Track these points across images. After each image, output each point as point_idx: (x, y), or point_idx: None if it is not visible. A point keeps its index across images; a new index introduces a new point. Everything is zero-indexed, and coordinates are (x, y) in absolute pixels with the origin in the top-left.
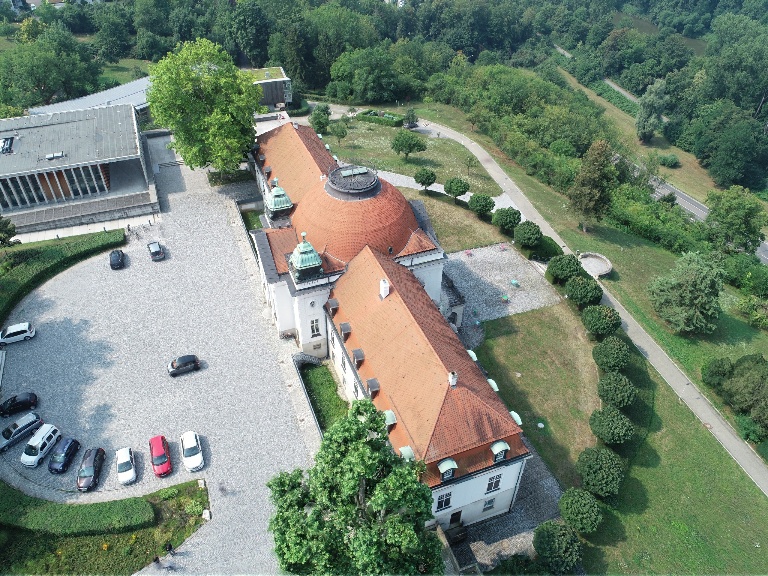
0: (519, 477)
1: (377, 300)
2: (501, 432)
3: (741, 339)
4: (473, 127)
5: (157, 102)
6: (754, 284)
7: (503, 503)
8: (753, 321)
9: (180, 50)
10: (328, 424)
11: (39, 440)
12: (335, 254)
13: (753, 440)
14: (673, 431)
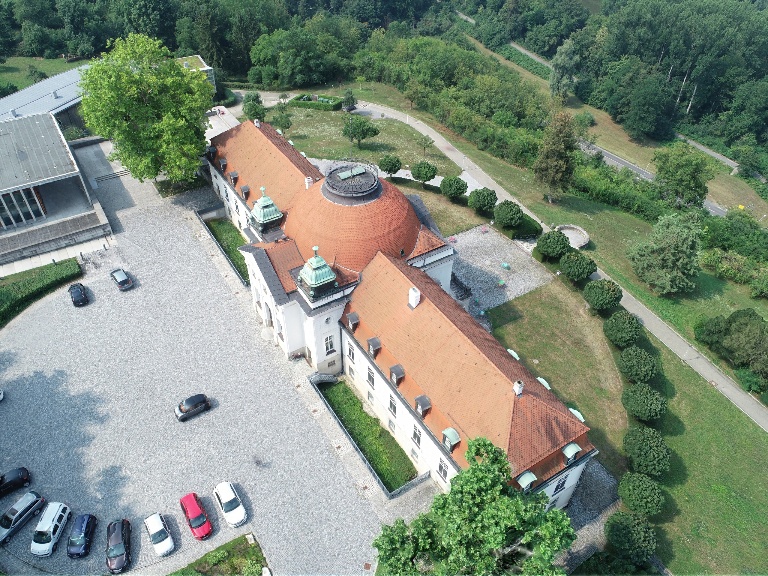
0: (581, 473)
1: (407, 310)
2: (571, 434)
3: (714, 292)
4: (411, 104)
5: (97, 111)
6: (712, 237)
7: (564, 500)
8: (720, 273)
9: (112, 49)
10: (364, 446)
11: (49, 524)
12: (346, 264)
13: (755, 391)
14: (686, 394)
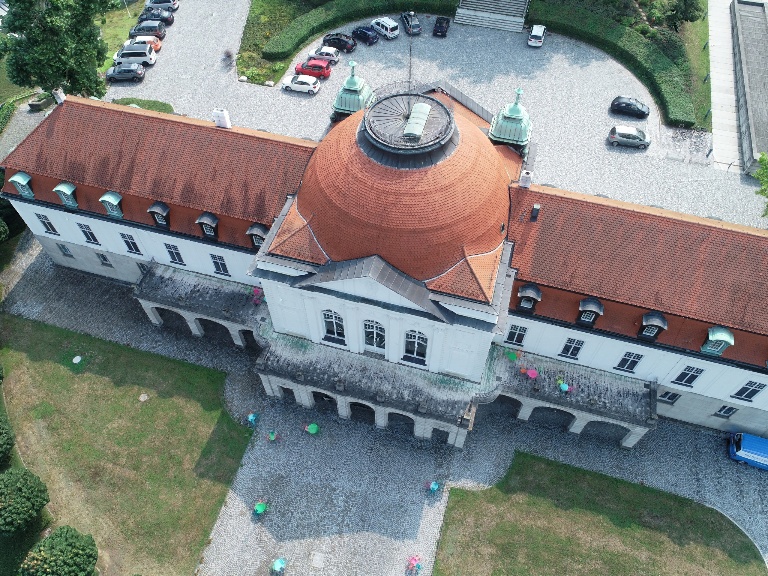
0: None
1: None
2: None
3: None
4: None
5: None
6: None
7: None
8: None
9: None
10: None
11: None
12: None
13: None
14: None
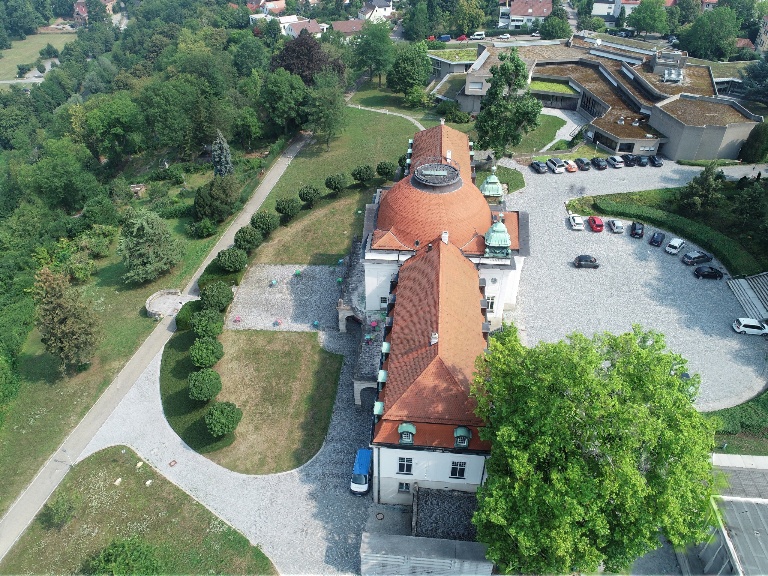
0: None
1: None
2: None
3: None
4: None
5: None
6: None
7: None
8: (96, 268)
9: None
10: None
11: None
12: None
13: None
14: None
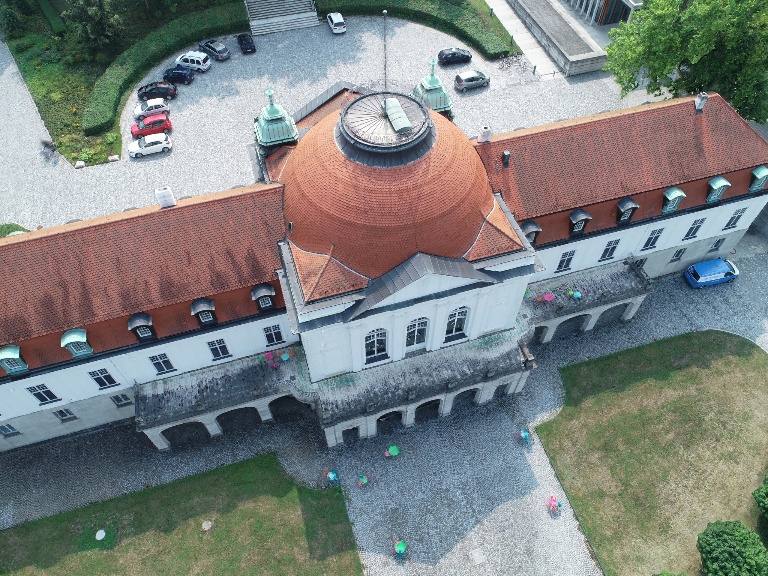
0: None
1: None
2: None
3: None
4: None
5: None
6: None
7: None
8: None
9: None
10: None
11: (189, 55)
12: None
13: None
14: None
